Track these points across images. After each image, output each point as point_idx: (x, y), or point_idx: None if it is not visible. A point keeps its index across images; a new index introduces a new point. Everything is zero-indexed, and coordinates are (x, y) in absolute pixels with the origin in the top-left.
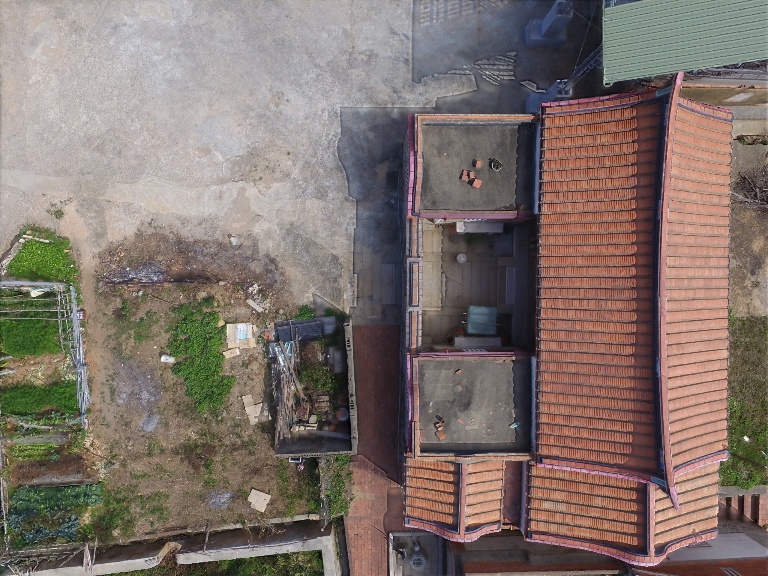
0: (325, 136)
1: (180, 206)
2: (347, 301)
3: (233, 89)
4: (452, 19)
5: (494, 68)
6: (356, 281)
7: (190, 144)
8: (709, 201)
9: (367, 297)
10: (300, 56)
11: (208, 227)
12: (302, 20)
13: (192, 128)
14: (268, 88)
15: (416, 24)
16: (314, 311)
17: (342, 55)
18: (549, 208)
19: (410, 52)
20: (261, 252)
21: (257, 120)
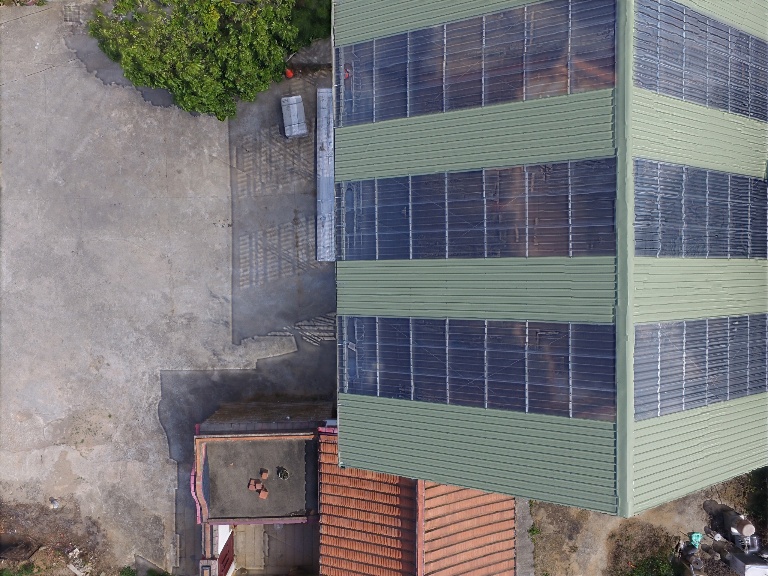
0: (146, 399)
1: (1, 470)
2: (170, 561)
3: (53, 353)
4: (272, 281)
5: (314, 329)
6: (178, 541)
7: (11, 408)
8: (488, 521)
9: (190, 557)
10: (120, 320)
11: (30, 491)
12: (121, 285)
13: (13, 392)
14: (88, 352)
15: (235, 287)
16: (136, 573)
17: (162, 319)
18: (327, 530)
19: (230, 315)
20: (83, 514)
21: (78, 384)
